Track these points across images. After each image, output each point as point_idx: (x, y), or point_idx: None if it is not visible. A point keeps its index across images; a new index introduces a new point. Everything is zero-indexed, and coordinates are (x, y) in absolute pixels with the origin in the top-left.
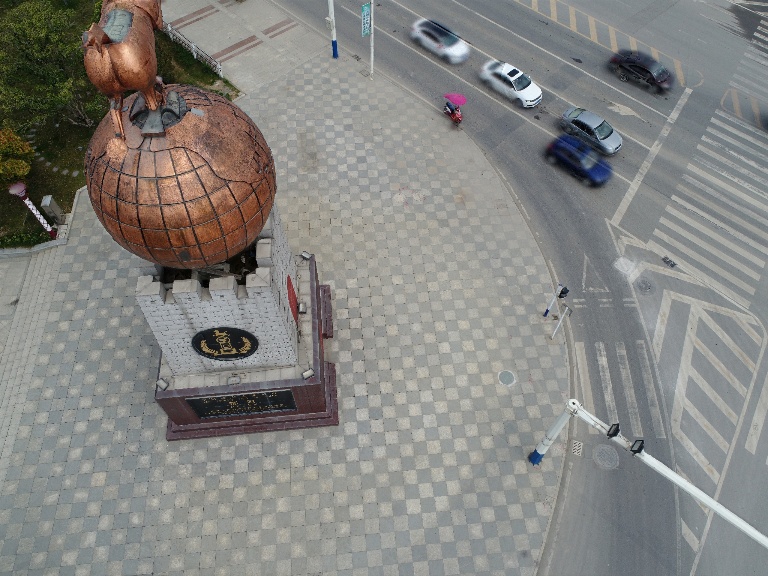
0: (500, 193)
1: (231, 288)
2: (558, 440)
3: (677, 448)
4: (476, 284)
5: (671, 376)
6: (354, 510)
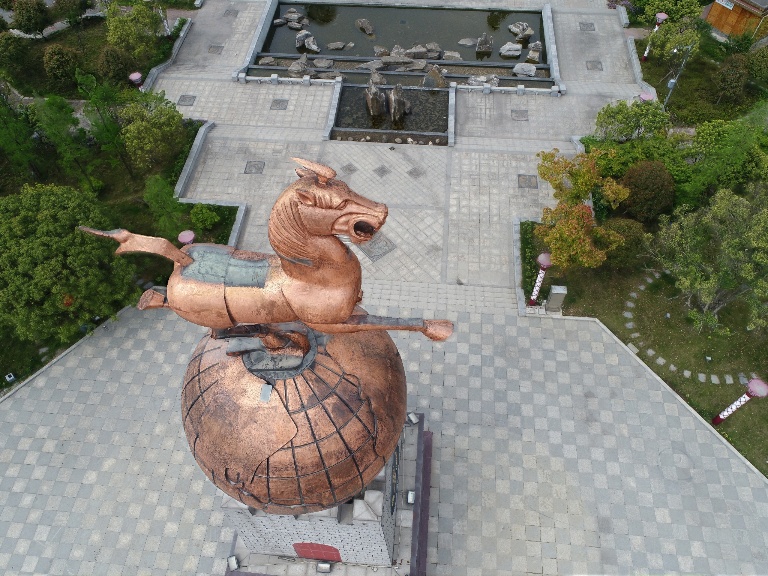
0: None
1: None
2: None
3: None
4: None
5: None
6: None
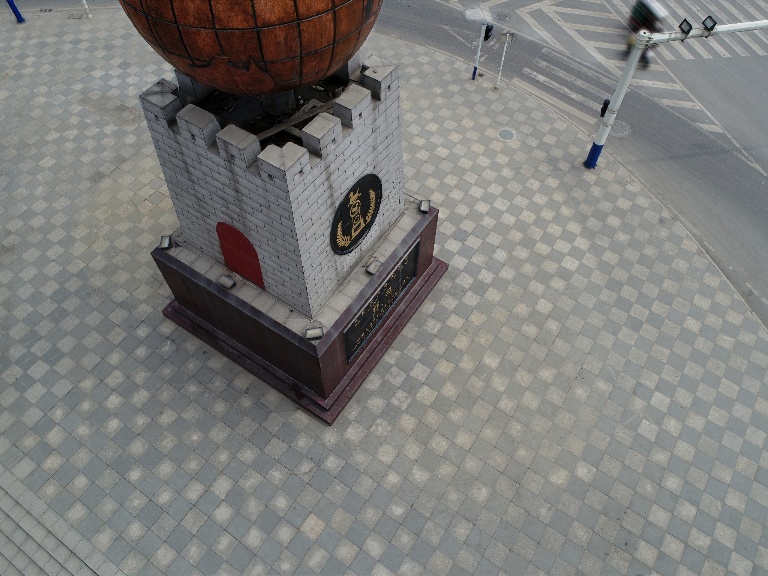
0: None
1: (368, 92)
2: (585, 142)
3: (642, 89)
4: (402, 95)
5: (586, 55)
6: (541, 307)
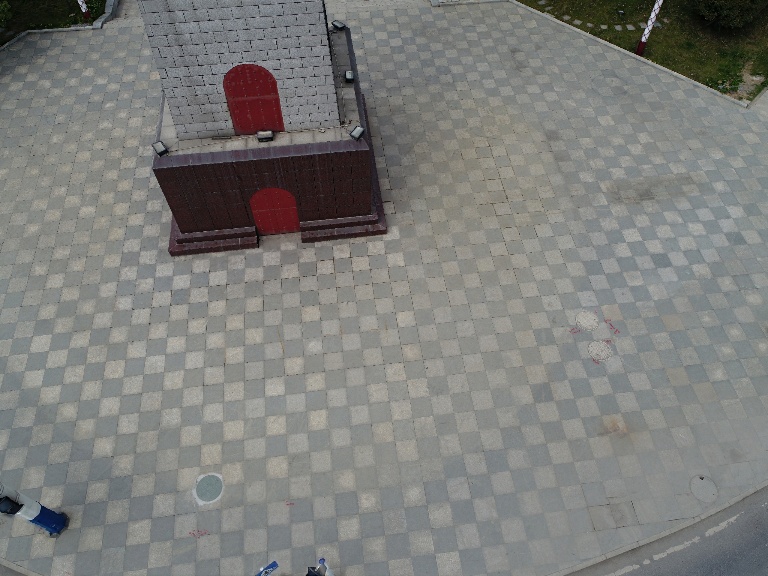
0: (655, 514)
1: None
2: (79, 573)
3: None
4: (405, 446)
5: None
6: (58, 278)
